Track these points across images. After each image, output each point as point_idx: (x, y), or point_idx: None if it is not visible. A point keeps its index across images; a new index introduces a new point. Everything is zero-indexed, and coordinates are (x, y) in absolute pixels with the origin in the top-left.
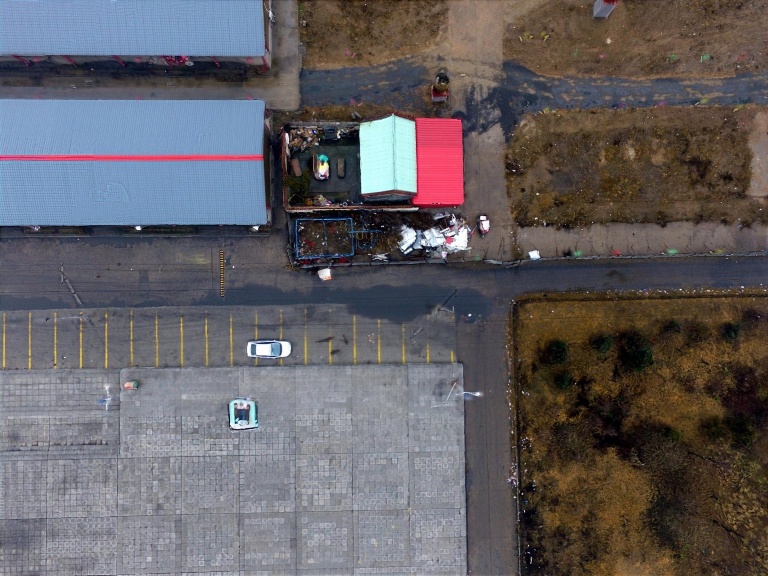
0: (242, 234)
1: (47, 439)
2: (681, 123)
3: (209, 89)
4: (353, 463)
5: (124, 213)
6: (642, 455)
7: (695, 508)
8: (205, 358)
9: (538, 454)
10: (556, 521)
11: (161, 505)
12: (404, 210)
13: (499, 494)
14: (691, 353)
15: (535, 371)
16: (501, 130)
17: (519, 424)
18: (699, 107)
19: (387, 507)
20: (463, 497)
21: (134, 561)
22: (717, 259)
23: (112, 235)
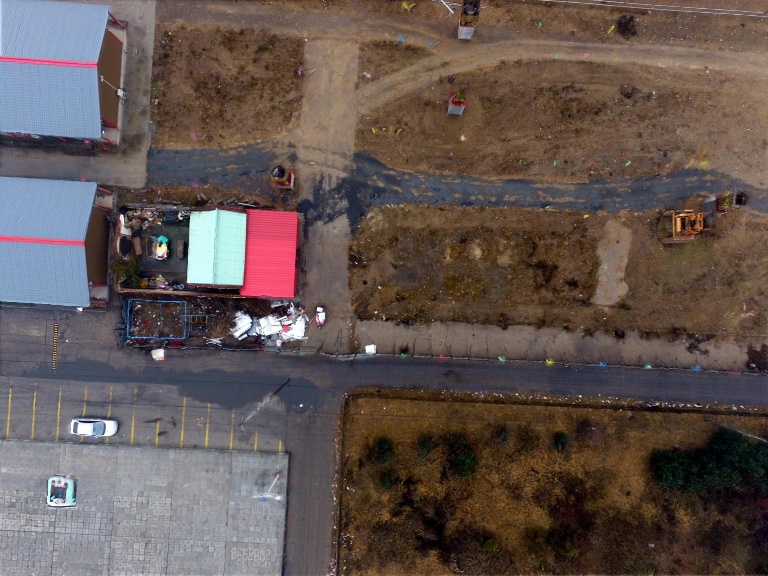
0: None
1: None
2: (530, 226)
3: (56, 161)
4: (169, 548)
5: None
6: (459, 563)
7: None
8: (31, 431)
9: (358, 552)
10: None
11: None
12: None
13: None
14: (522, 460)
15: (362, 467)
16: (347, 221)
17: (341, 520)
18: (549, 211)
19: None
20: None
21: None
22: (556, 366)
23: None
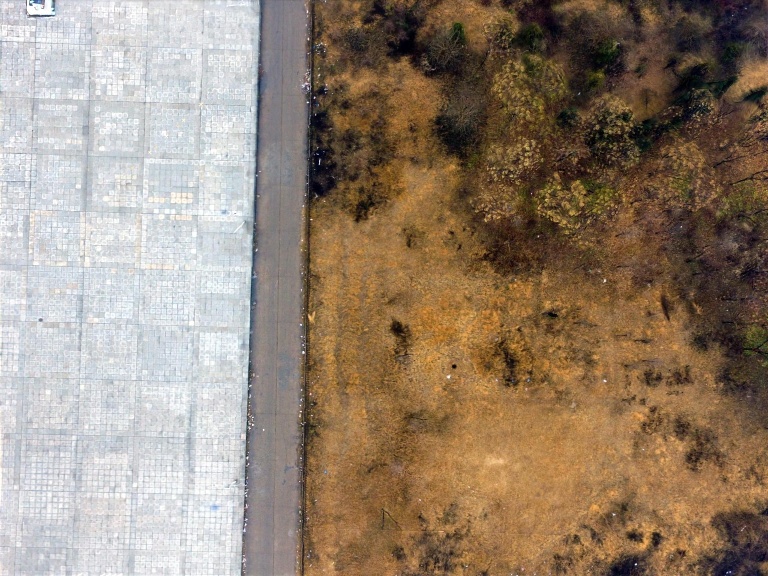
0: None
1: None
2: None
3: None
4: (147, 56)
5: None
6: (429, 54)
7: (485, 119)
8: None
9: (331, 59)
10: (346, 124)
11: None
12: None
13: (292, 99)
14: None
15: None
16: None
17: (314, 29)
18: None
19: (179, 101)
20: (255, 96)
21: None
22: None
23: None
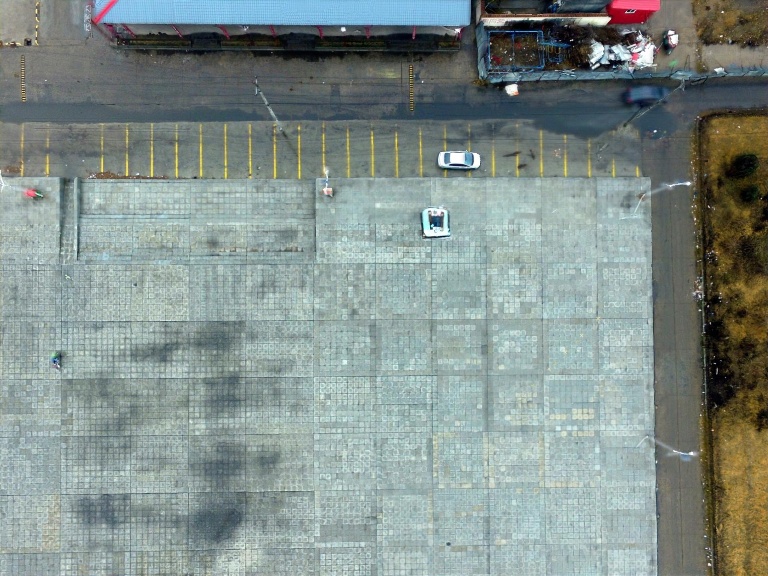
0: (431, 49)
1: (245, 245)
2: None
3: None
4: (543, 273)
5: (339, 5)
6: None
7: None
8: (395, 170)
9: (724, 267)
10: (742, 332)
11: (356, 310)
12: (594, 23)
13: (684, 307)
14: None
15: (721, 186)
16: None
17: (705, 237)
18: None
19: (576, 316)
20: (651, 308)
21: (330, 364)
22: None
23: (304, 49)
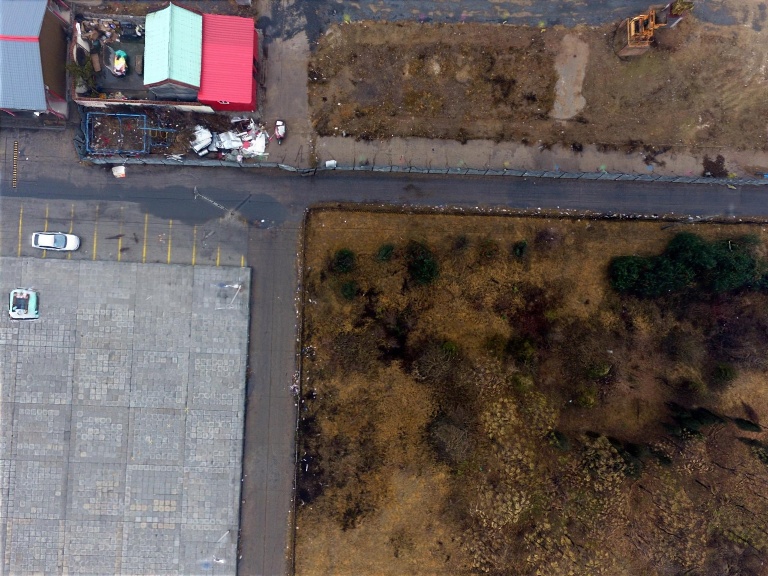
0: (37, 126)
1: None
2: (488, 41)
3: None
4: (133, 360)
5: None
6: (420, 367)
7: (475, 425)
8: None
9: (321, 362)
10: (334, 430)
11: None
12: (199, 110)
13: (280, 401)
14: (482, 271)
15: (324, 280)
16: (306, 38)
17: (304, 332)
18: (507, 26)
19: (164, 406)
20: (242, 400)
21: None
22: (515, 179)
23: None
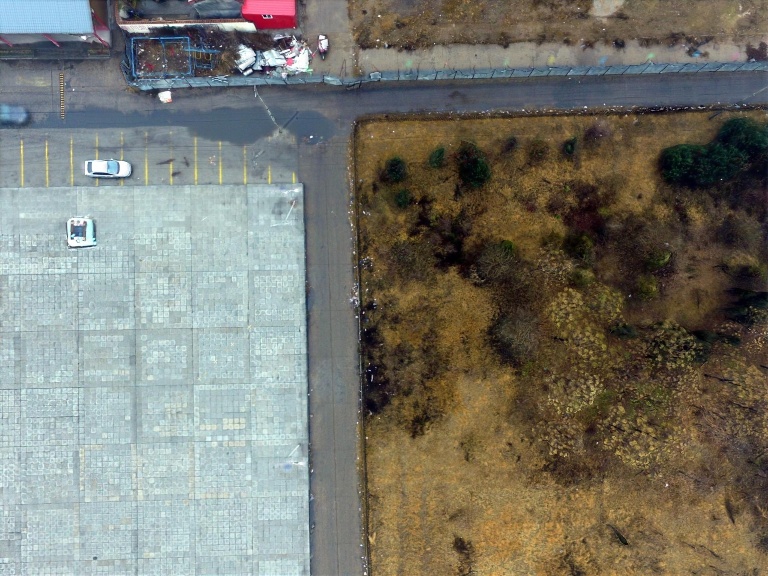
0: (82, 56)
1: None
2: None
3: None
4: (192, 281)
5: None
6: (479, 269)
7: (537, 326)
8: (45, 180)
9: (379, 273)
10: (397, 339)
11: None
12: (242, 29)
13: (341, 314)
14: (533, 172)
15: (376, 191)
16: None
17: (360, 243)
18: None
19: (227, 325)
20: (303, 315)
21: None
22: (560, 79)
23: None
